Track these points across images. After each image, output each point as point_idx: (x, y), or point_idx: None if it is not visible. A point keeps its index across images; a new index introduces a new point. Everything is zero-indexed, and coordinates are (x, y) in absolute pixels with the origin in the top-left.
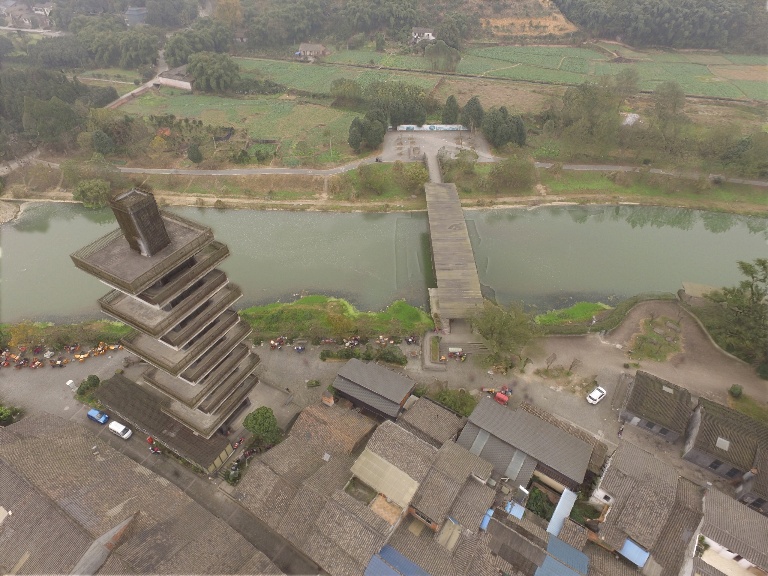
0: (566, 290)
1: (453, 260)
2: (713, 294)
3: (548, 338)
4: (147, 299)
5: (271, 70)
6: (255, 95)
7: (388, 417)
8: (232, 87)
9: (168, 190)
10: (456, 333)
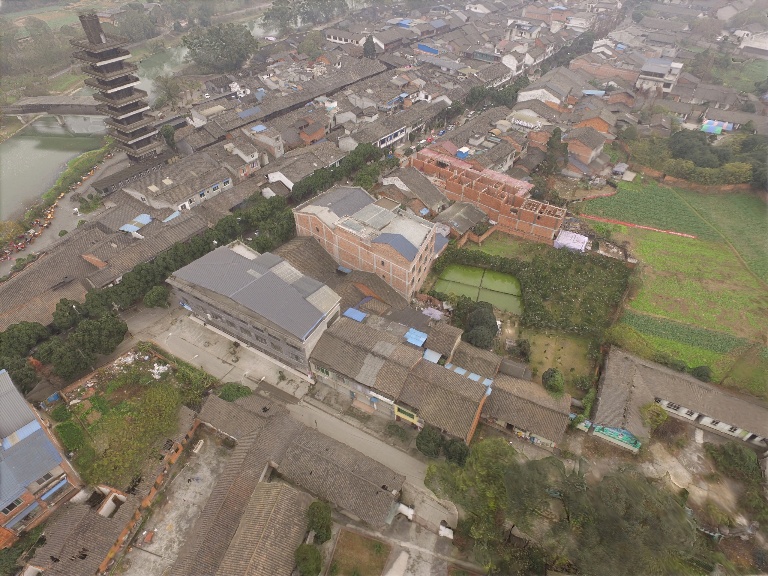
0: None
1: None
2: None
3: None
4: (126, 53)
5: None
6: None
7: (184, 124)
8: None
9: None
10: None
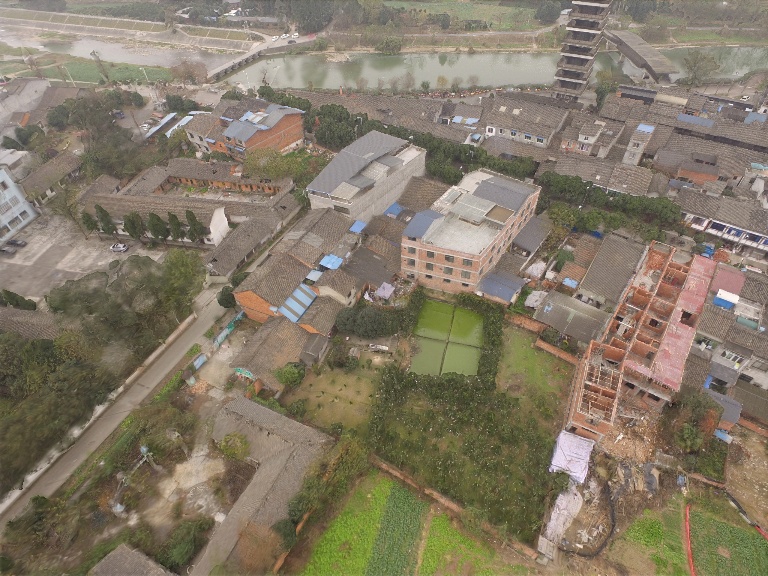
0: None
1: (650, 54)
2: None
3: (711, 86)
4: (605, 2)
5: None
6: None
7: (650, 100)
8: None
9: (432, 45)
10: (662, 83)
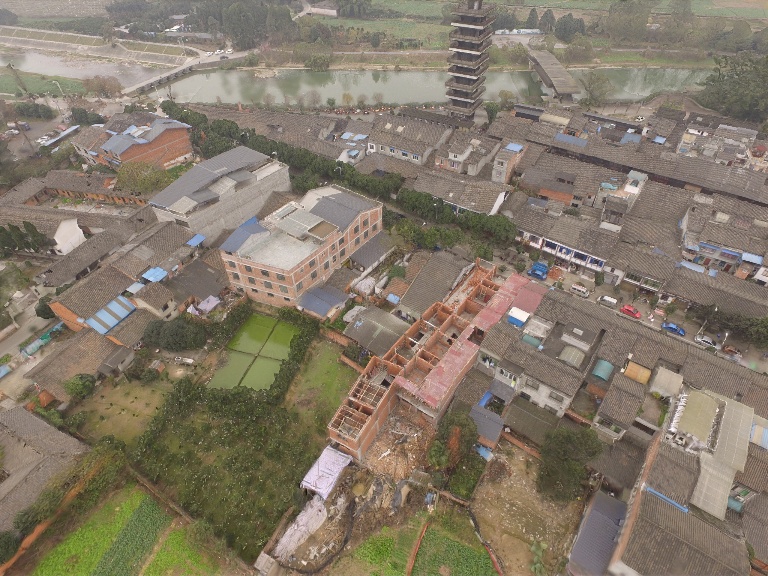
0: (619, 98)
1: (558, 75)
2: (700, 83)
3: (613, 106)
4: (479, 24)
5: (388, 4)
6: (384, 19)
7: None
8: (366, 14)
9: (361, 62)
10: (565, 103)
